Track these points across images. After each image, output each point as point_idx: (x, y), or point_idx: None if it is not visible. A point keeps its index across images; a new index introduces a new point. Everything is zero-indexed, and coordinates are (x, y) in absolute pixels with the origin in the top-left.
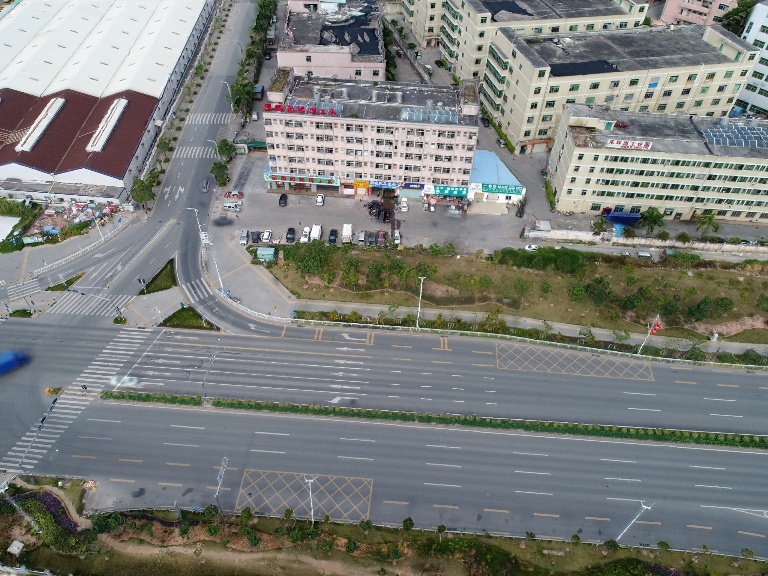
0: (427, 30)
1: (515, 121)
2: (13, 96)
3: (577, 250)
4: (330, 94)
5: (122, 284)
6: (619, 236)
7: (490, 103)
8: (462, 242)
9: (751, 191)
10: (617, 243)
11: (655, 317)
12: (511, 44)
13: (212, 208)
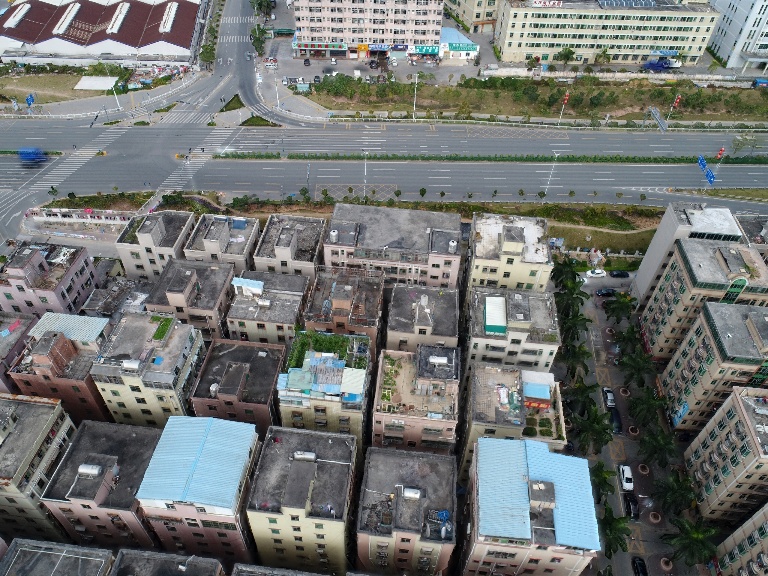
0: None
1: (469, 7)
2: (88, 4)
3: None
4: None
5: (206, 108)
6: (545, 70)
7: (449, 0)
8: (438, 80)
9: (632, 37)
10: (544, 77)
11: (569, 110)
12: None
13: None
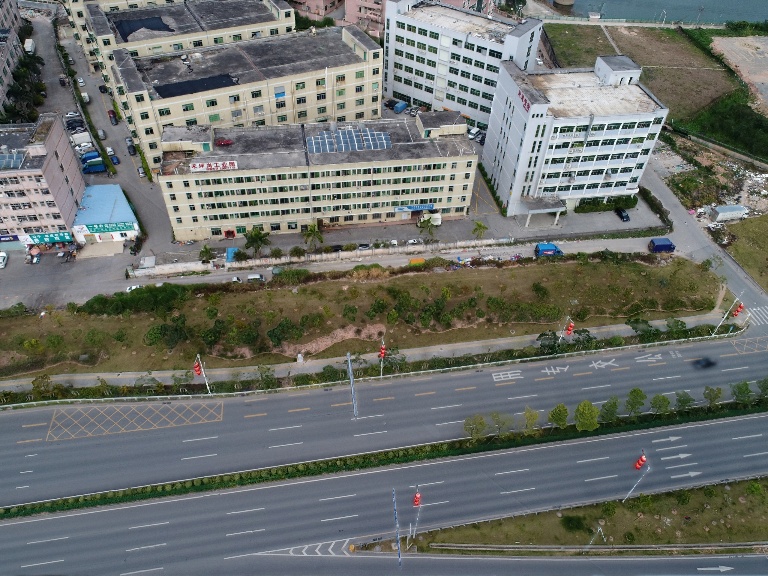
0: (88, 54)
1: None
2: None
3: (180, 284)
4: None
5: None
6: (230, 261)
7: None
8: (58, 294)
9: (361, 194)
10: (233, 268)
11: (244, 346)
12: (117, 68)
13: None
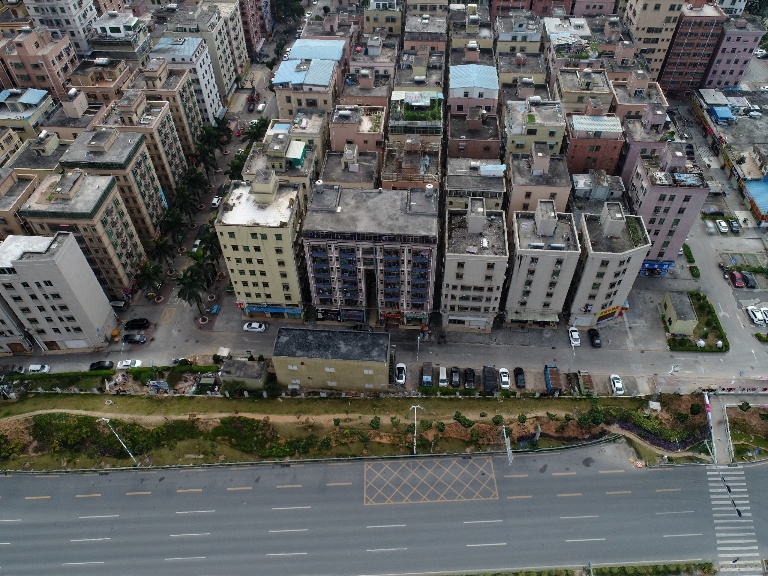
0: None
1: None
2: None
3: None
4: None
5: None
6: None
7: None
8: None
9: None
10: None
11: None
12: None
13: None
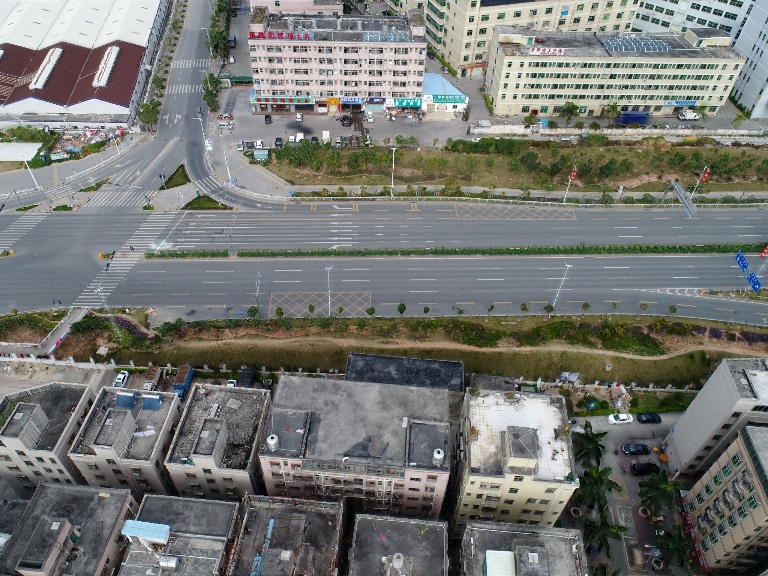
0: None
1: (455, 49)
2: (13, 49)
3: (513, 139)
4: (302, 25)
5: (144, 184)
6: (545, 128)
7: (433, 38)
8: (421, 140)
9: (644, 87)
10: (544, 134)
11: (575, 179)
12: None
13: (208, 128)
